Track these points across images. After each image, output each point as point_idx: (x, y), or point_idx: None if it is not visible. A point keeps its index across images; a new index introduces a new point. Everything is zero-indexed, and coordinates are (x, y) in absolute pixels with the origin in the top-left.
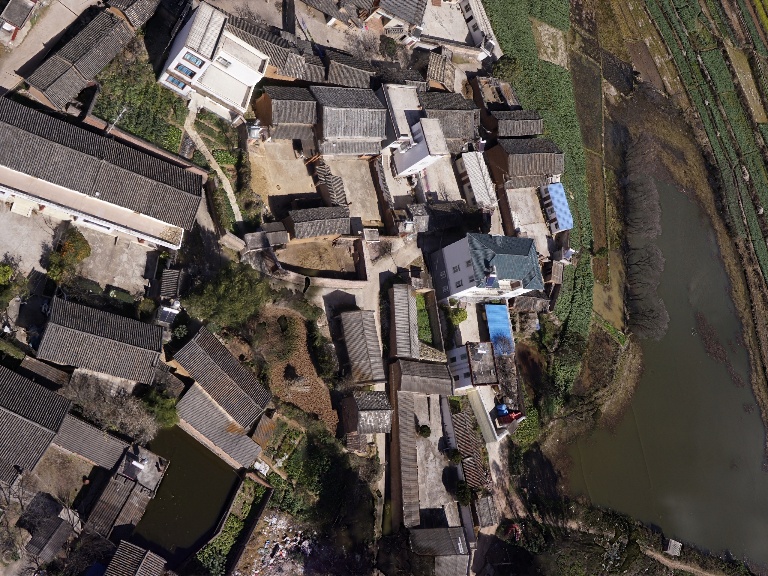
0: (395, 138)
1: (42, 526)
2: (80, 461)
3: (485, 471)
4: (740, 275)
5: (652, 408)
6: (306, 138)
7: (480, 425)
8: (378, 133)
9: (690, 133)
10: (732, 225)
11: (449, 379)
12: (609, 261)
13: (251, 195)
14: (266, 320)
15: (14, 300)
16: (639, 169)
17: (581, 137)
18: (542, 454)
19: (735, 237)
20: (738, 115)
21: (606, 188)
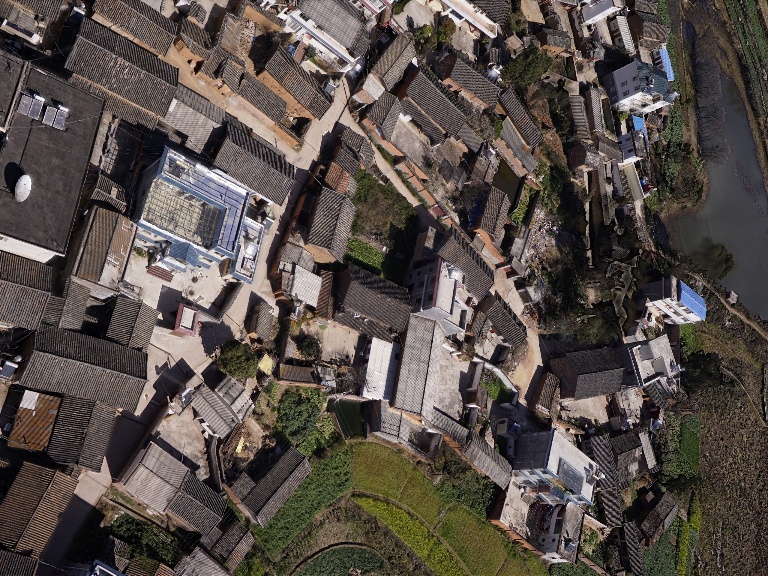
0: None
1: None
2: (457, 148)
3: None
4: (761, 144)
5: (716, 213)
6: None
7: (631, 189)
8: None
9: (730, 39)
10: (757, 108)
11: (621, 152)
12: (688, 112)
13: (522, 15)
14: (531, 93)
15: None
16: (705, 54)
17: (670, 25)
18: (660, 220)
19: (759, 117)
20: (759, 32)
21: (685, 64)
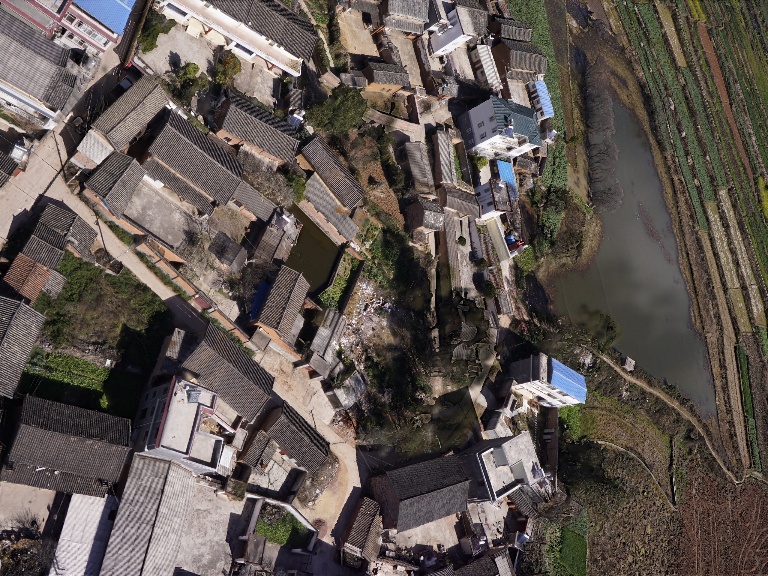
0: (437, 20)
1: (229, 248)
2: (242, 216)
3: (501, 281)
4: (669, 181)
5: (610, 265)
6: (374, 13)
7: (496, 248)
8: (423, 16)
9: (630, 67)
10: (663, 142)
11: (477, 205)
12: (576, 151)
13: (341, 47)
14: None
15: None
16: (596, 84)
17: (554, 53)
18: (537, 280)
19: (665, 152)
20: (665, 58)
21: (572, 96)
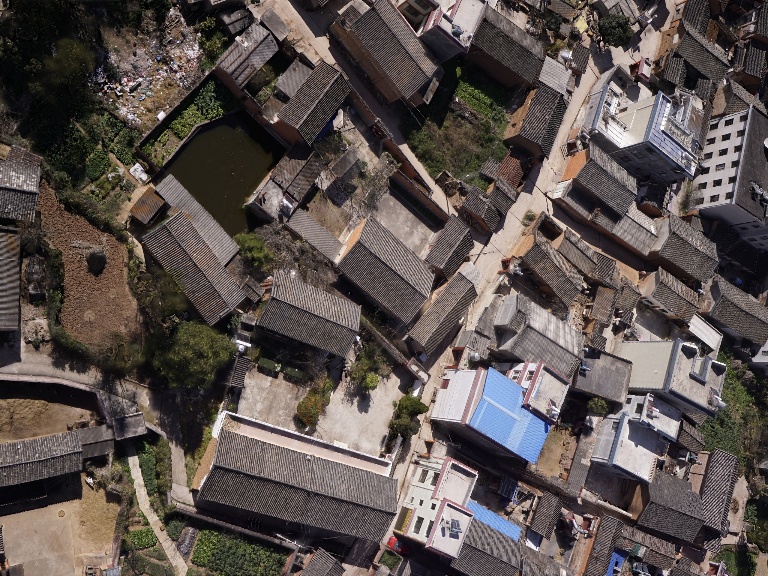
0: None
1: None
2: None
3: None
4: None
5: None
6: None
7: None
8: None
9: None
10: None
11: None
12: None
13: (124, 489)
14: (117, 332)
15: (349, 364)
16: None
17: None
18: None
19: None
20: None
21: None
